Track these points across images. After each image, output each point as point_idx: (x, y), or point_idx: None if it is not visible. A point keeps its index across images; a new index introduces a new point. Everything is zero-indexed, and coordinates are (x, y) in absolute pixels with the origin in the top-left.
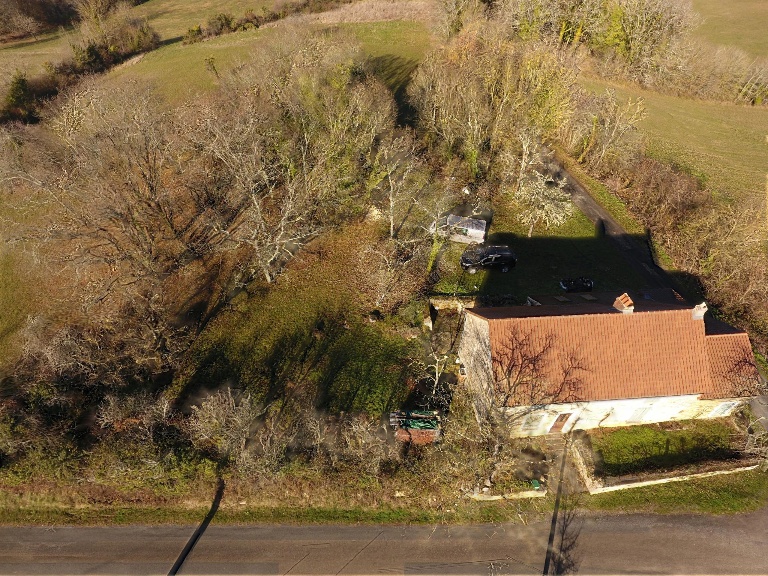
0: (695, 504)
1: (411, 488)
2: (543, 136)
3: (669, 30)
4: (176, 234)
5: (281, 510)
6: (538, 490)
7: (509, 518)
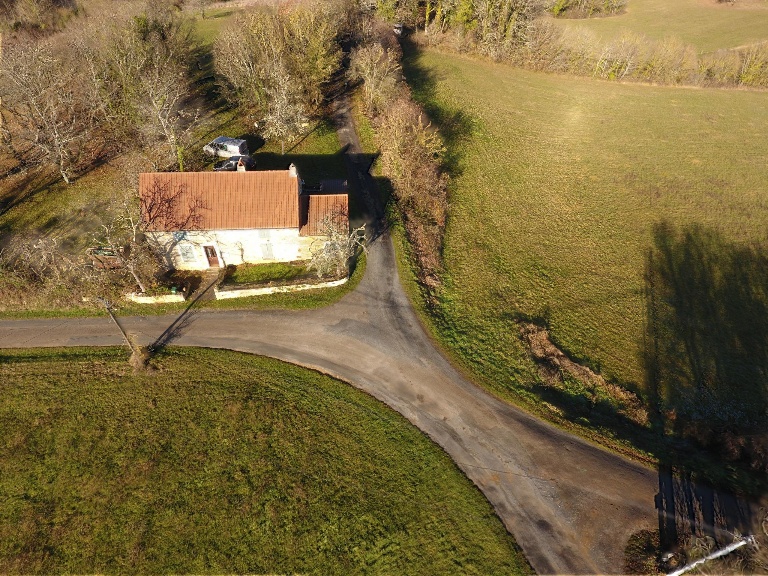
0: (284, 305)
1: (92, 294)
2: (318, 81)
3: (508, 9)
4: (15, 154)
5: (6, 312)
6: (176, 294)
7: (154, 313)
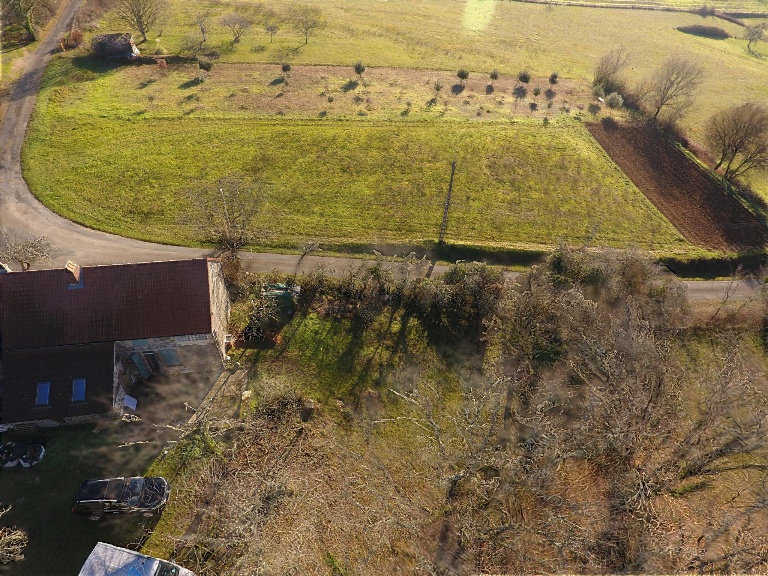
0: None
1: None
2: None
3: None
4: None
5: None
6: None
7: None
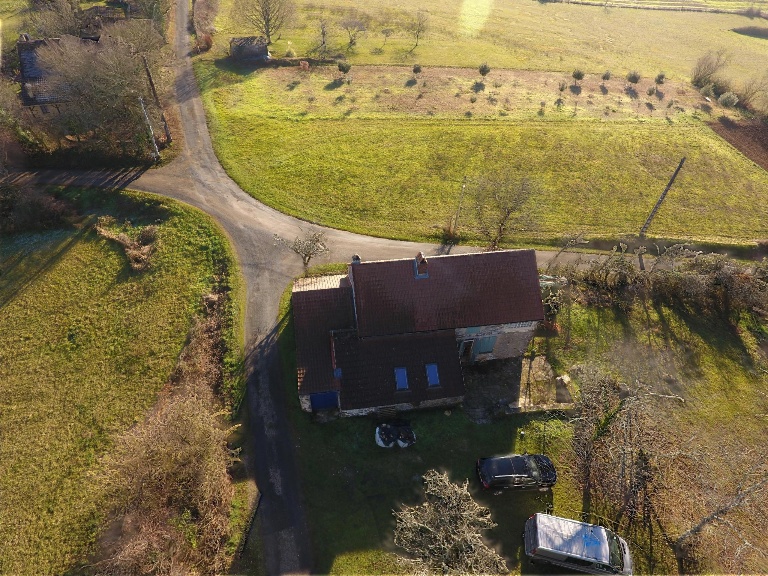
0: None
1: None
2: None
3: None
4: None
5: None
6: None
7: None
